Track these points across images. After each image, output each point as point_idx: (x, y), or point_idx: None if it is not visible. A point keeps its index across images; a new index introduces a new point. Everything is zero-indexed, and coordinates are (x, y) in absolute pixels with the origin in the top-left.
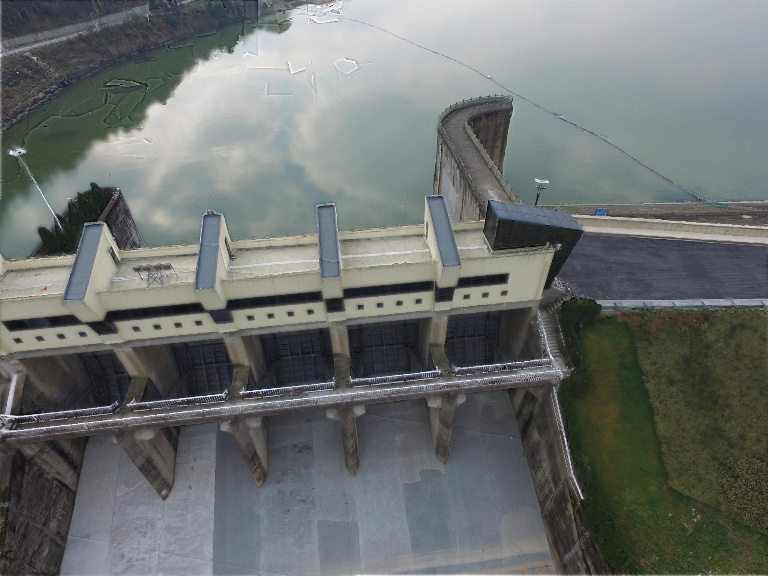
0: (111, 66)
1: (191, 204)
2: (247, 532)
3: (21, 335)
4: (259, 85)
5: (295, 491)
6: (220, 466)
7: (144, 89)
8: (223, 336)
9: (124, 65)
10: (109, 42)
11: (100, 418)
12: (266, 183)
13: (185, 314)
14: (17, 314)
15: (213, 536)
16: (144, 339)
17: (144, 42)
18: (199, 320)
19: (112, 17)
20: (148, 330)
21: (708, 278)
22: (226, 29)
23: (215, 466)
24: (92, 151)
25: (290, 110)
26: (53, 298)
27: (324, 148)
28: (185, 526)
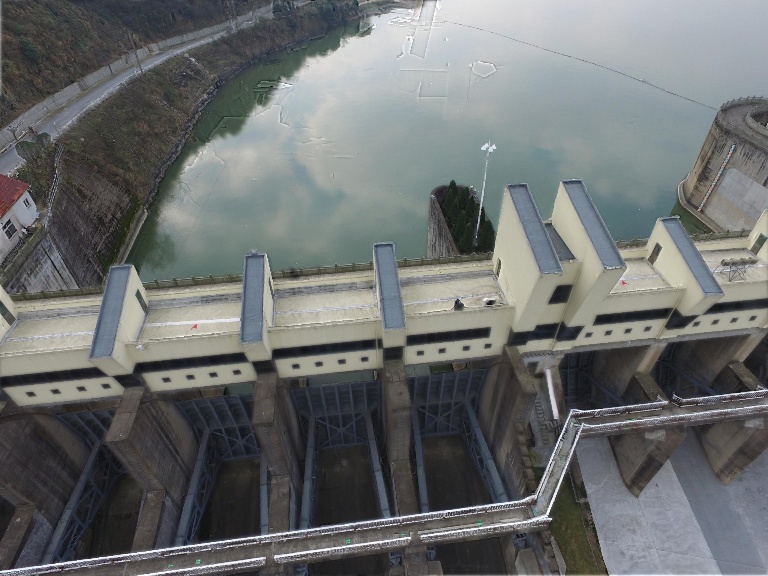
0: (247, 68)
1: None
2: (734, 530)
3: (597, 329)
4: (411, 87)
5: (761, 489)
6: (676, 463)
7: (298, 91)
8: (754, 331)
9: (256, 67)
10: (244, 44)
11: (652, 413)
12: (495, 183)
13: (751, 309)
14: (617, 308)
15: (703, 534)
16: (687, 334)
17: (271, 44)
18: (756, 315)
19: (238, 19)
20: (704, 325)
21: None
22: (332, 32)
23: (671, 463)
24: (295, 151)
25: (439, 112)
26: (664, 291)
27: (527, 149)
28: (670, 524)
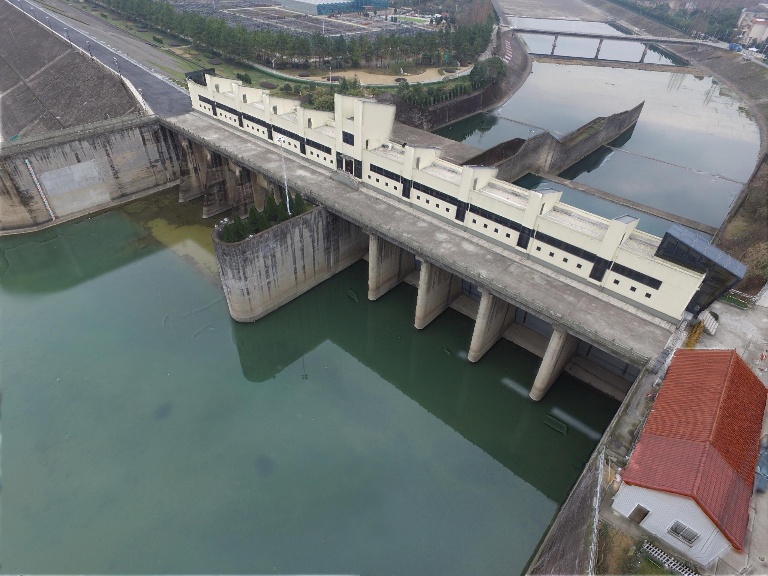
0: None
1: (90, 384)
2: None
3: None
4: None
5: None
6: None
7: None
8: None
9: None
10: None
11: None
12: (3, 355)
13: None
14: None
15: None
16: None
17: None
18: None
19: None
20: None
21: (168, 92)
22: None
23: None
24: None
25: None
26: None
27: None
28: None
